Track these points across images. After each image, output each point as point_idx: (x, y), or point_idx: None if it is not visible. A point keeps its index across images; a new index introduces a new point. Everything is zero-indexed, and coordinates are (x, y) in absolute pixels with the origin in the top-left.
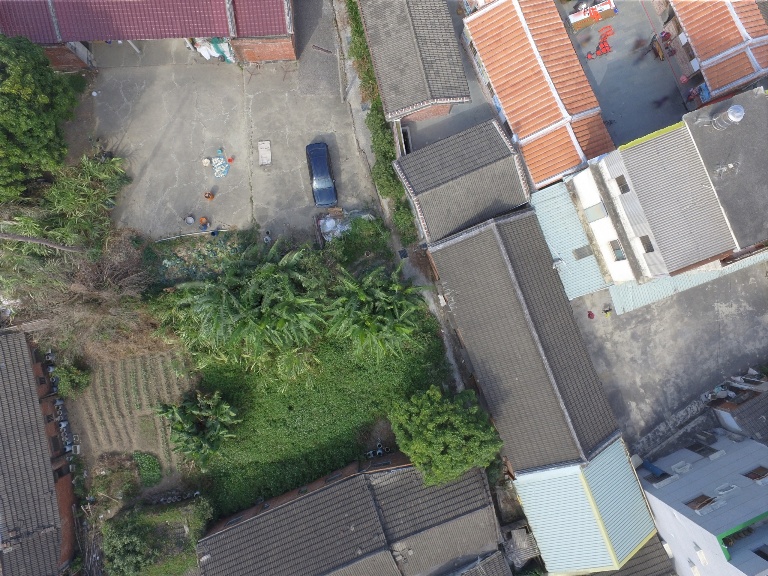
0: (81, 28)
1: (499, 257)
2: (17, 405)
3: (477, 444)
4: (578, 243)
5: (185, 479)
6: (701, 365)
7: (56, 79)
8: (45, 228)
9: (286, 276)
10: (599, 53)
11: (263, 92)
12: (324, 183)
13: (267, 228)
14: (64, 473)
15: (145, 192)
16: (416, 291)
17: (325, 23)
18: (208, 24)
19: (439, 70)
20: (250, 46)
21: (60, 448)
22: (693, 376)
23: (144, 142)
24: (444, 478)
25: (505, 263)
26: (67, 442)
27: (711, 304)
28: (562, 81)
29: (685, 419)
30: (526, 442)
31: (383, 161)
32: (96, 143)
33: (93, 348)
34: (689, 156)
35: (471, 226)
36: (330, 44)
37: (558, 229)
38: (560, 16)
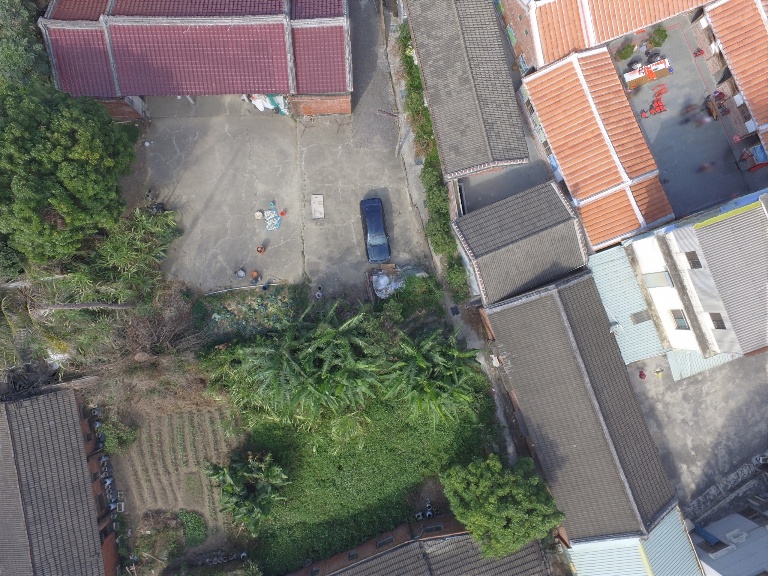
0: (141, 83)
1: (559, 323)
2: (65, 464)
3: (540, 519)
4: (636, 307)
5: (231, 539)
6: (752, 428)
7: (117, 137)
8: (98, 283)
9: (347, 342)
10: (653, 112)
11: (317, 145)
12: (378, 239)
13: (318, 283)
14: (108, 532)
15: (196, 244)
16: (473, 354)
17: (380, 76)
18: (269, 81)
19: (500, 132)
20: (308, 102)
21: (105, 506)
22: (744, 439)
23: (196, 194)
24: (504, 552)
25: (566, 330)
26: (112, 499)
27: (762, 366)
28: (621, 144)
29: (736, 482)
30: (583, 511)
31: (437, 218)
32: (148, 194)
33: (141, 404)
34: (765, 236)
35: (528, 288)
36: (384, 98)
37: (615, 293)
38: (618, 77)
